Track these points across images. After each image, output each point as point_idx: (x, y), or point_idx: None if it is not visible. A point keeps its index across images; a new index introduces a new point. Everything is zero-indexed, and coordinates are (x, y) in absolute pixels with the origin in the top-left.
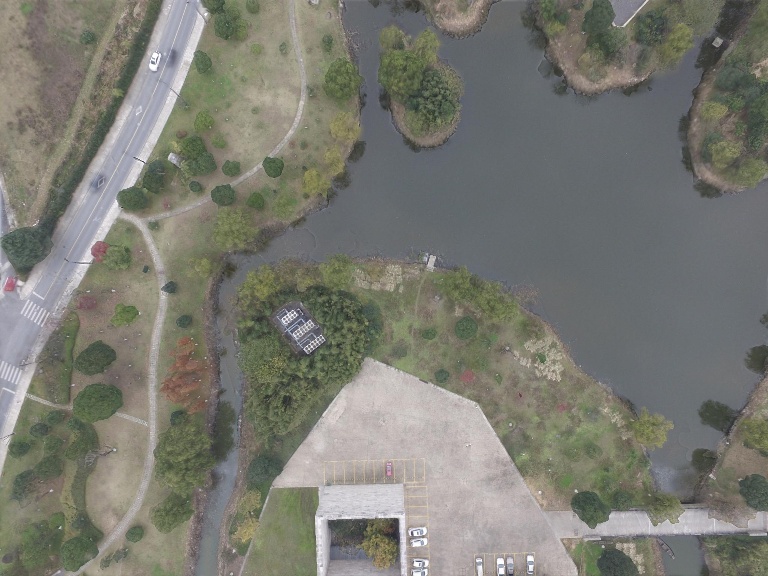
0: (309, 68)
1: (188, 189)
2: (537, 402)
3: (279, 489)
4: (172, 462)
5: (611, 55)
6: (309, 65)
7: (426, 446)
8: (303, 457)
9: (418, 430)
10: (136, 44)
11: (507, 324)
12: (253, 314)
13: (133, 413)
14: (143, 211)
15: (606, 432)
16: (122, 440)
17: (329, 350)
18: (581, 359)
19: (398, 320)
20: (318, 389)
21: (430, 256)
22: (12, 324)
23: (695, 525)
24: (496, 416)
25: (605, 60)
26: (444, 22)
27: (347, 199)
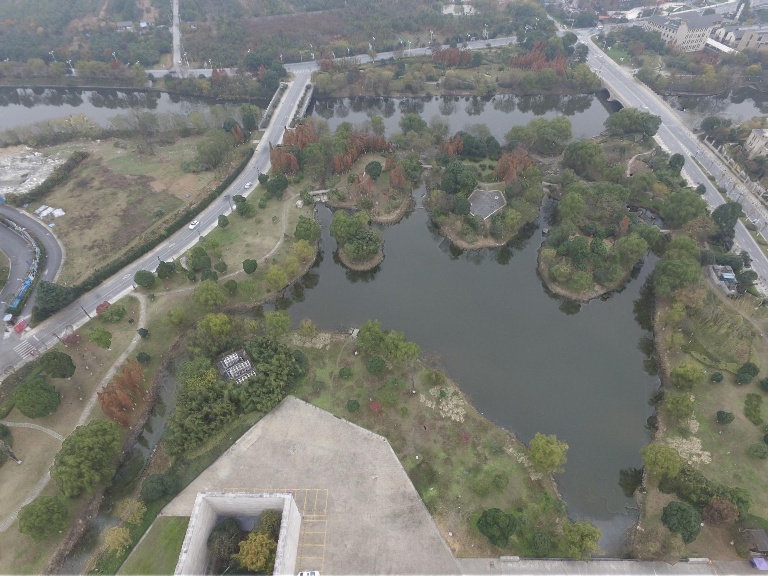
0: (288, 230)
1: (186, 281)
2: (443, 439)
3: (167, 517)
4: (76, 449)
5: (477, 229)
6: (289, 229)
7: (332, 477)
8: (204, 483)
9: (326, 460)
10: (186, 214)
11: (410, 363)
12: (202, 351)
13: (58, 429)
14: (148, 291)
15: (514, 471)
16: (33, 454)
17: (257, 375)
18: (482, 408)
19: (322, 368)
20: (238, 418)
21: (354, 329)
22: (0, 356)
23: None
24: (403, 450)
25: (474, 232)
26: (376, 218)
27: (300, 309)
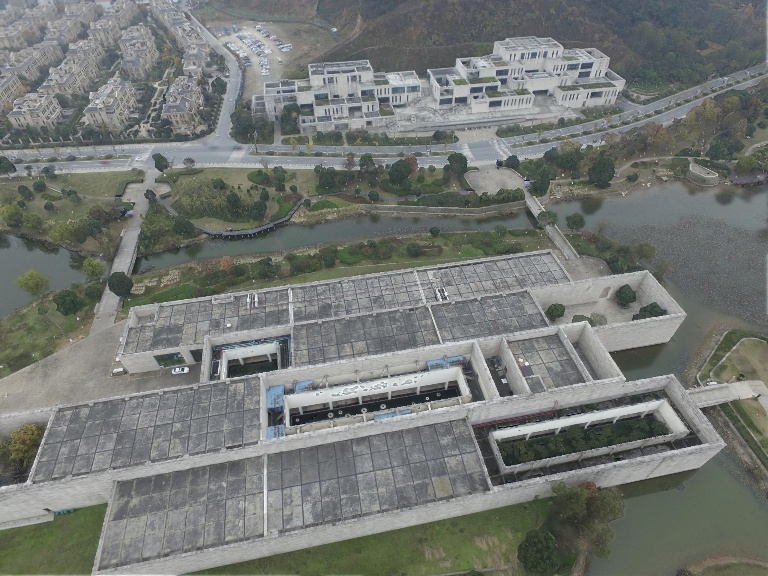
0: None
1: None
2: None
3: None
4: None
5: None
6: None
7: None
8: None
9: None
10: None
11: None
12: None
13: None
14: None
15: None
16: None
17: None
18: None
19: None
20: None
21: None
22: None
23: (127, 257)
24: None
25: None
26: None
27: None
